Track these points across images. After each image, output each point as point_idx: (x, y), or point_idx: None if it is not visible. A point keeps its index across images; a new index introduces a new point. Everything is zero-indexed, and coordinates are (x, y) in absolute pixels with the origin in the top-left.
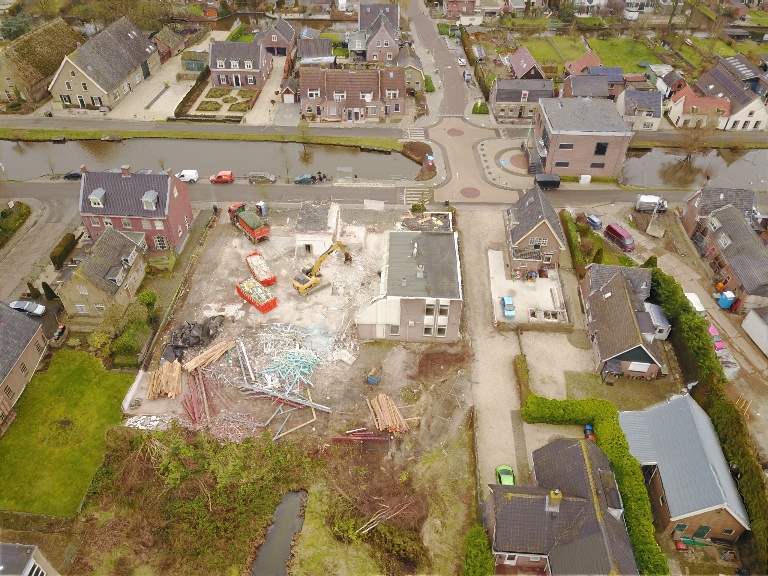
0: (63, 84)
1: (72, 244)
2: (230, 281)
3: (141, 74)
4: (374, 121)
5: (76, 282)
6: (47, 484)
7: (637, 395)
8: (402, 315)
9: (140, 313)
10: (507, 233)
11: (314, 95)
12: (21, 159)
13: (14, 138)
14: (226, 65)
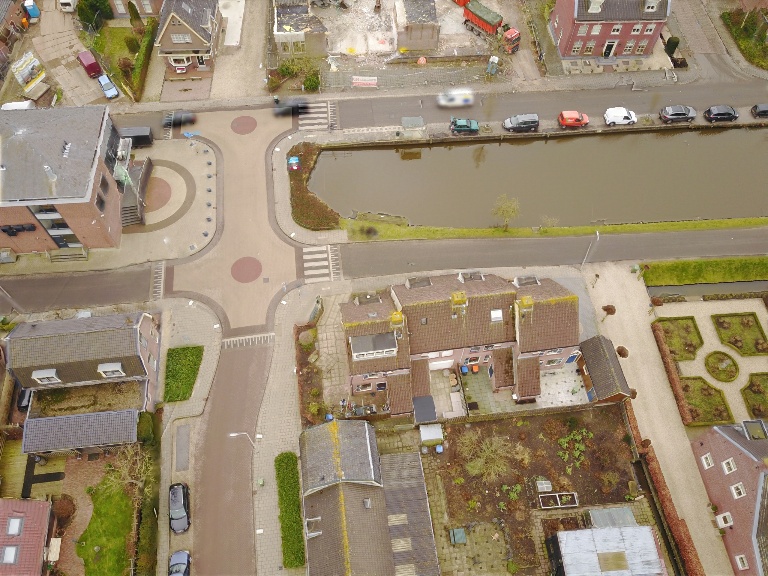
0: None
1: None
2: None
3: None
4: None
5: None
6: None
7: None
8: None
9: None
10: None
11: None
12: None
13: None
14: None
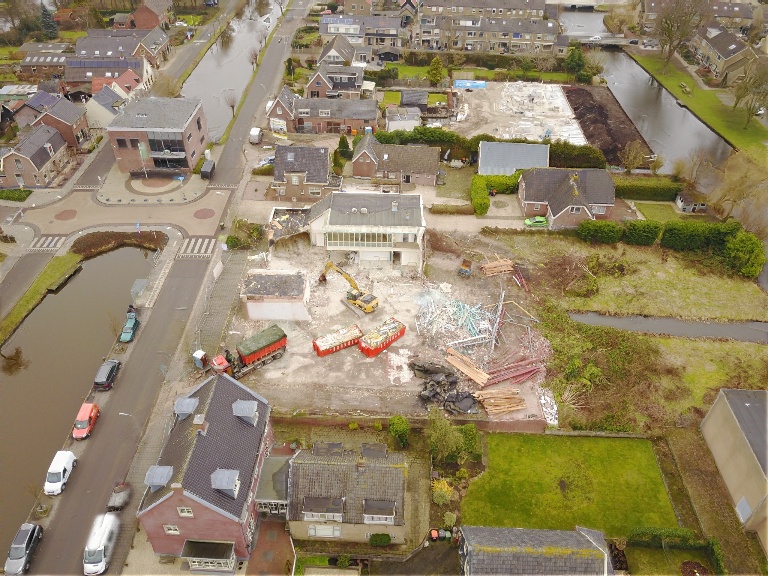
0: None
1: None
2: (350, 369)
3: None
4: None
5: None
6: (631, 475)
7: (452, 177)
8: None
9: None
10: (288, 196)
11: None
12: None
13: None
14: None
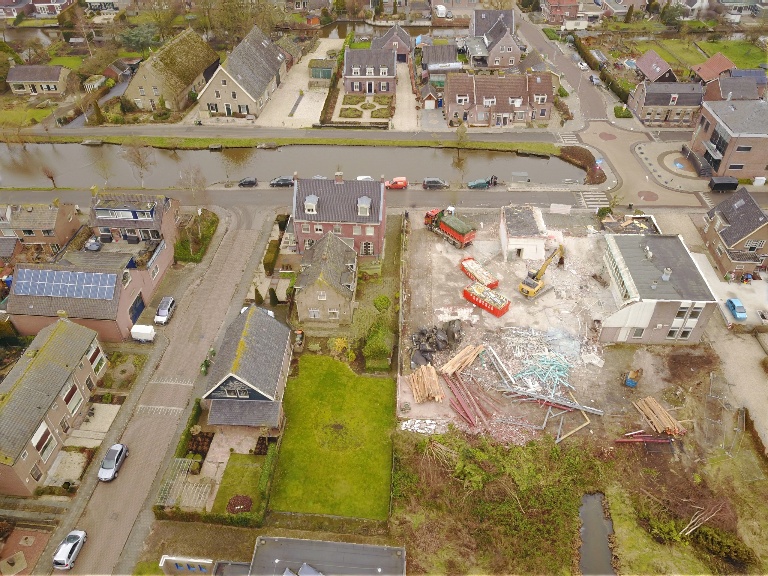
0: (212, 93)
1: (277, 250)
2: (450, 286)
3: (275, 82)
4: (523, 126)
5: (318, 288)
6: (345, 487)
7: None
8: (652, 318)
9: (388, 318)
10: (706, 236)
11: (463, 101)
12: (176, 167)
13: (172, 146)
14: (361, 72)
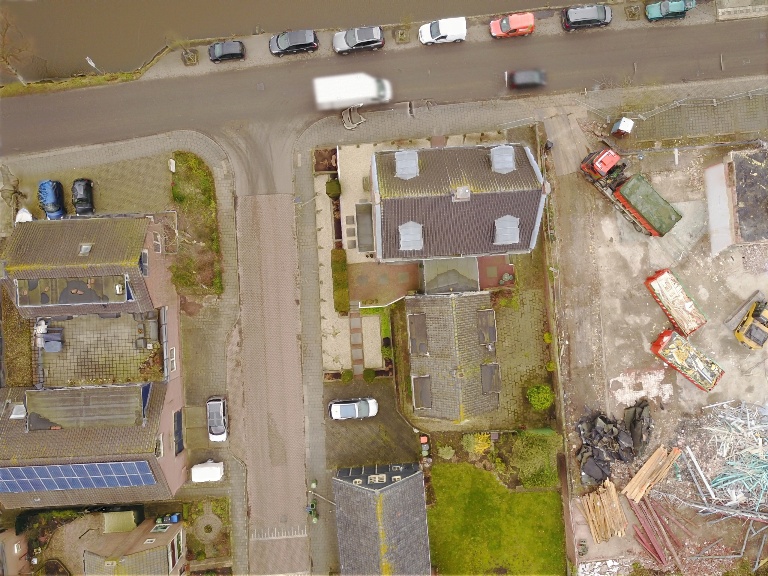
0: None
1: None
2: (630, 324)
3: None
4: None
5: None
6: None
7: None
8: None
9: None
10: None
11: None
12: None
13: None
14: None
